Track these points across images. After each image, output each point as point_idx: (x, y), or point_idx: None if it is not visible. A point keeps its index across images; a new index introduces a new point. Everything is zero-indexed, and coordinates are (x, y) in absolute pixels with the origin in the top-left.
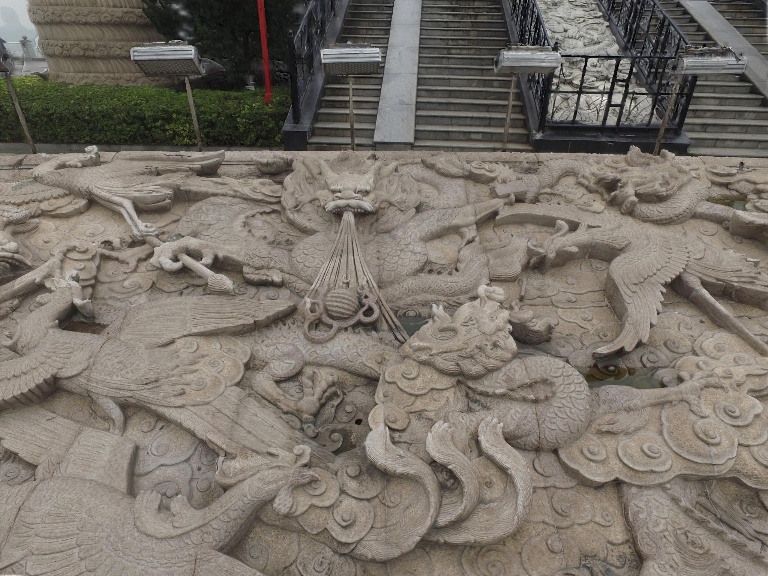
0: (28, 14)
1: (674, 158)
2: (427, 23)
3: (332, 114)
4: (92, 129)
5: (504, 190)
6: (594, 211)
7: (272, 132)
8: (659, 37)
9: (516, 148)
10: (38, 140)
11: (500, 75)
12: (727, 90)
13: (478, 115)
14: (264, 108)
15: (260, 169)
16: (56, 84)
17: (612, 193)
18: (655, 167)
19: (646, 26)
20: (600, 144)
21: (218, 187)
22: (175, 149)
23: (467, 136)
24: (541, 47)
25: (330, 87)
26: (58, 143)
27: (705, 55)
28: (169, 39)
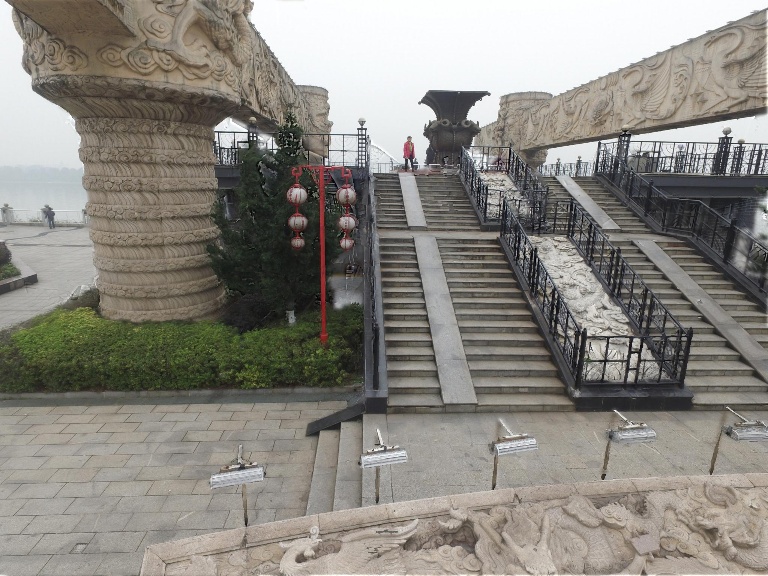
0: (93, 260)
1: (730, 479)
2: (447, 265)
3: (398, 371)
4: (164, 378)
5: (642, 548)
6: (714, 568)
7: (334, 375)
8: (645, 302)
9: (561, 404)
10: (106, 388)
11: (521, 319)
12: (696, 331)
13: (520, 368)
14: (327, 355)
15: (446, 531)
16: (119, 326)
17: (716, 543)
18: (734, 510)
19: (630, 287)
20: (626, 399)
21: (431, 567)
22: (242, 392)
23: (516, 390)
24: (641, 426)
25: (388, 340)
26: (127, 391)
27: (749, 429)
28: (227, 283)
